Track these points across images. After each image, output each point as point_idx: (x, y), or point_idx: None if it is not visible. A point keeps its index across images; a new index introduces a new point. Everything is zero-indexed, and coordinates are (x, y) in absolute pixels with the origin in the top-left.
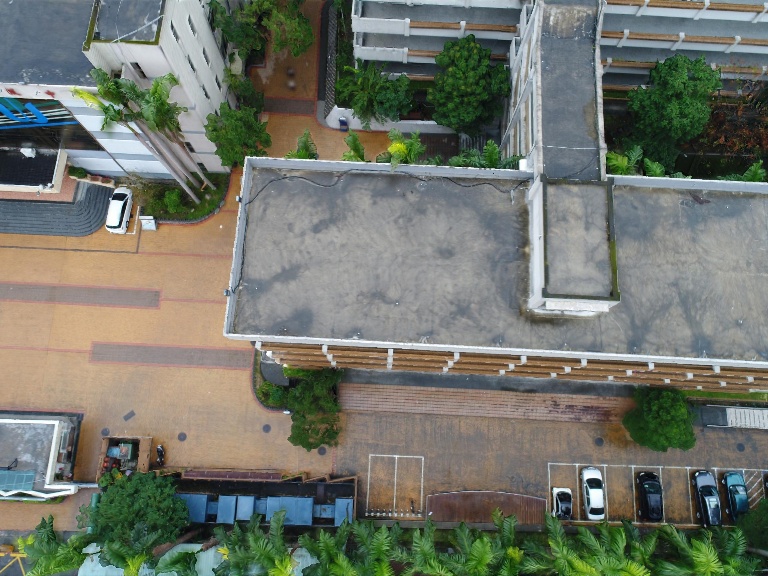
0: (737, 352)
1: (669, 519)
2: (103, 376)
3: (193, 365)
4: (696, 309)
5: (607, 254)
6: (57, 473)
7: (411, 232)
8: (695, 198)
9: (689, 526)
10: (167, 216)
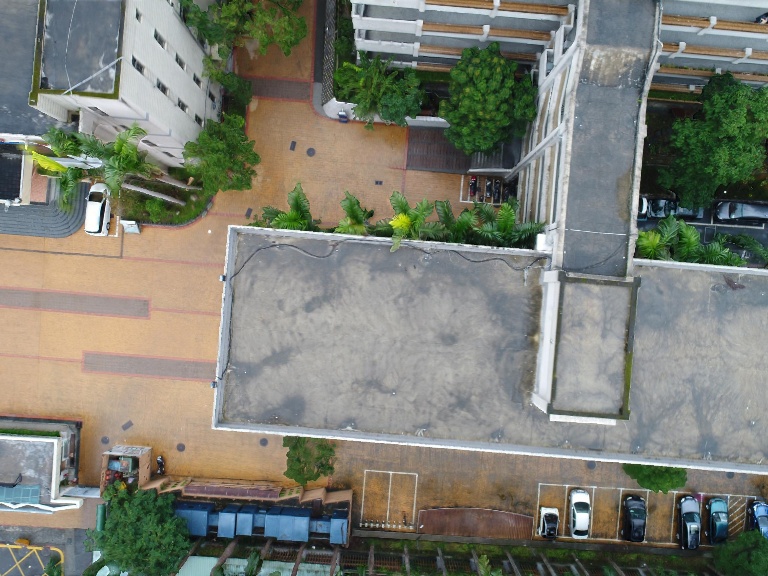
0: (743, 455)
1: (649, 538)
2: (98, 386)
3: (188, 378)
4: (708, 408)
5: (622, 366)
6: (62, 480)
7: (412, 314)
8: (729, 282)
9: (667, 545)
10: (150, 219)
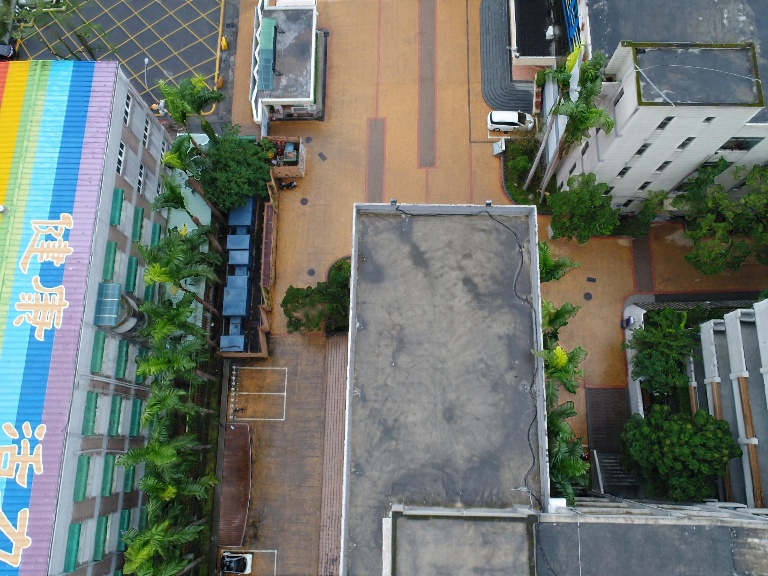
0: None
1: None
2: (356, 131)
3: None
4: None
5: None
6: (275, 108)
7: (471, 377)
8: None
9: None
10: None
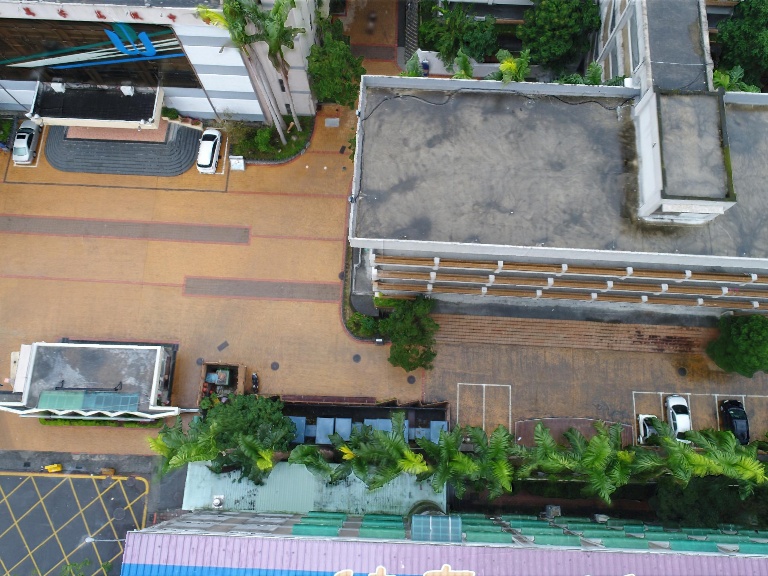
0: None
1: None
2: (197, 309)
3: (283, 298)
4: None
5: (721, 159)
6: None
7: (522, 146)
8: None
9: None
10: (255, 156)
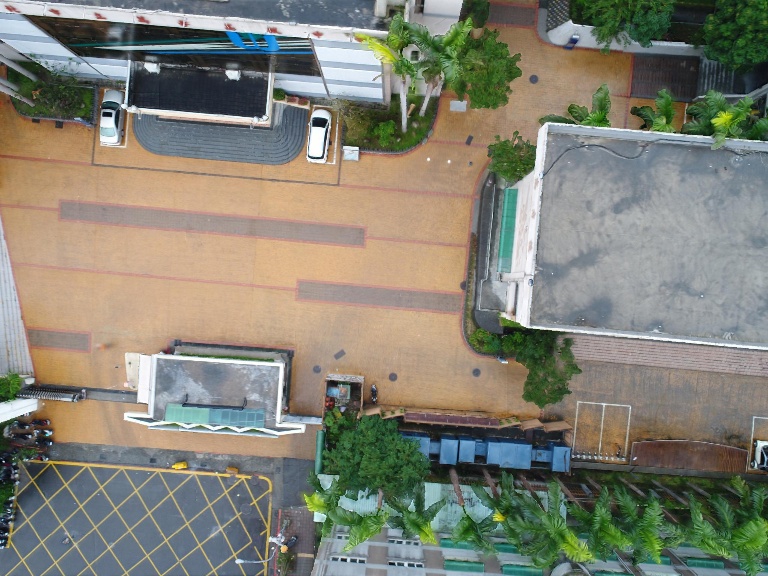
0: None
1: None
2: (311, 315)
3: (402, 307)
4: None
5: None
6: None
7: (722, 216)
8: None
9: None
10: (371, 146)
